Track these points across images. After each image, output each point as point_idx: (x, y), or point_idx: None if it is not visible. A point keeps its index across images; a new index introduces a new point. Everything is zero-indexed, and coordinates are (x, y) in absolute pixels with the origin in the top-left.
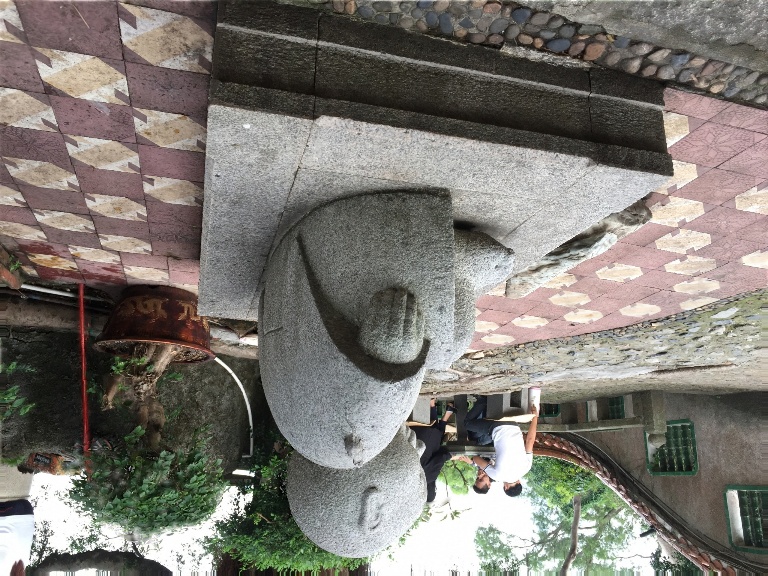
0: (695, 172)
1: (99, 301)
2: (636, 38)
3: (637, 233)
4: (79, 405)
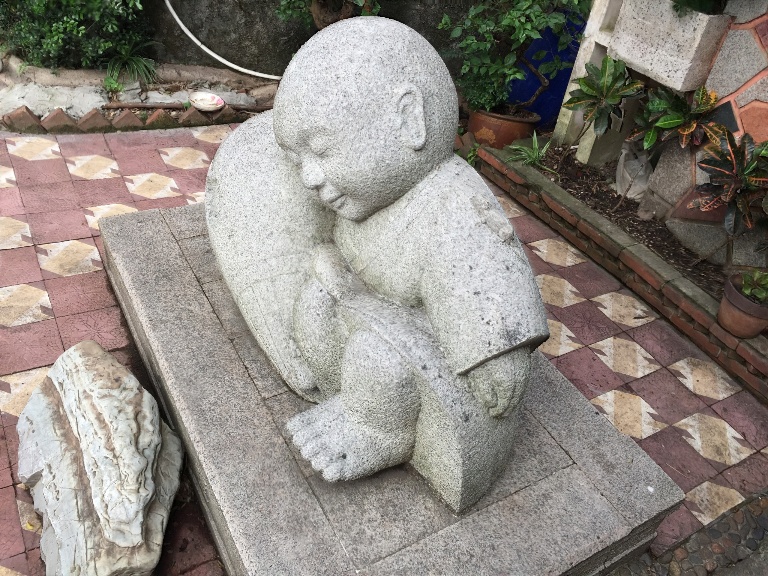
0: None
1: None
2: None
3: None
4: None
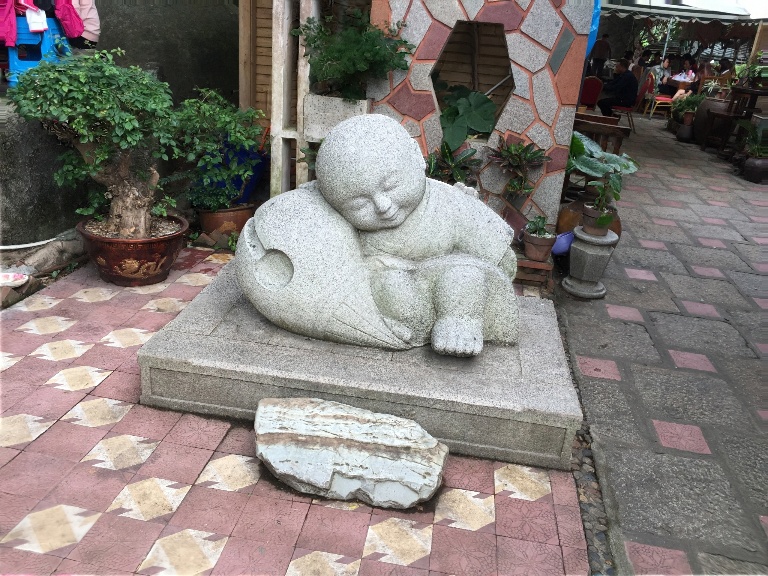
0: (482, 526)
1: None
2: (594, 455)
3: (334, 530)
4: None
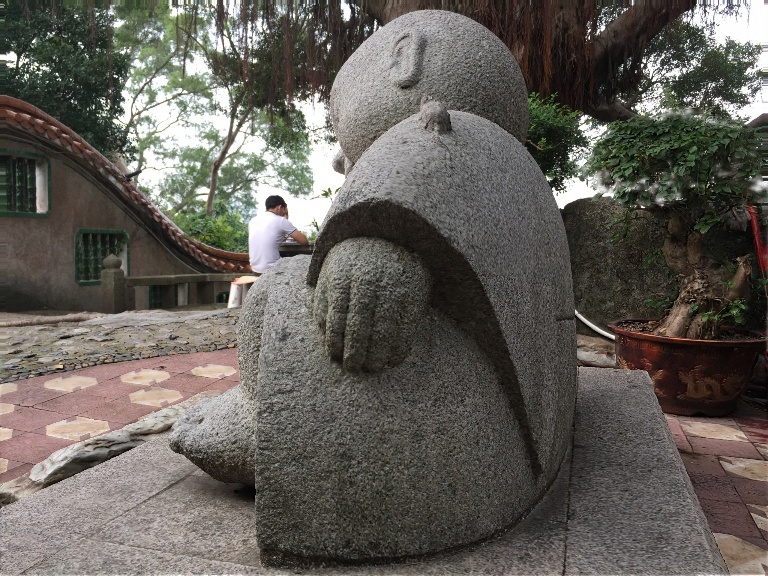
0: None
1: (759, 398)
2: None
3: None
4: (767, 270)
